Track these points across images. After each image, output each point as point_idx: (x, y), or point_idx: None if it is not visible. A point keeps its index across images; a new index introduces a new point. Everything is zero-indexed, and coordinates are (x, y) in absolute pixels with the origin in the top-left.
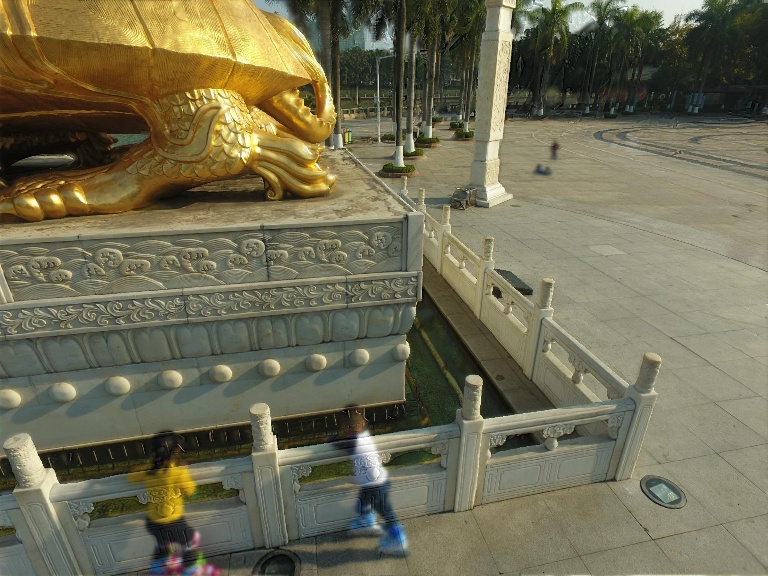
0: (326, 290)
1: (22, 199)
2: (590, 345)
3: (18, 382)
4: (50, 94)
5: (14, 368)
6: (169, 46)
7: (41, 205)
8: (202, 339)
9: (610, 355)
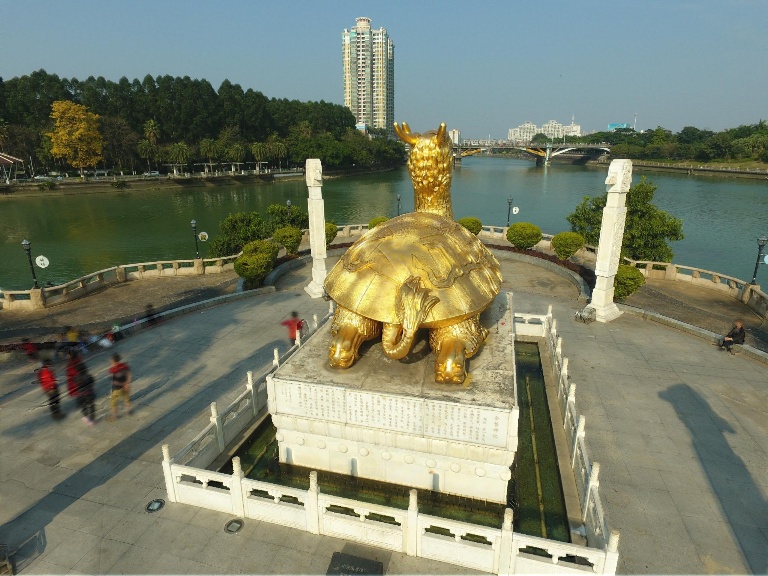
0: None
1: None
2: (231, 572)
3: None
4: None
5: None
6: None
7: None
8: None
9: (213, 574)
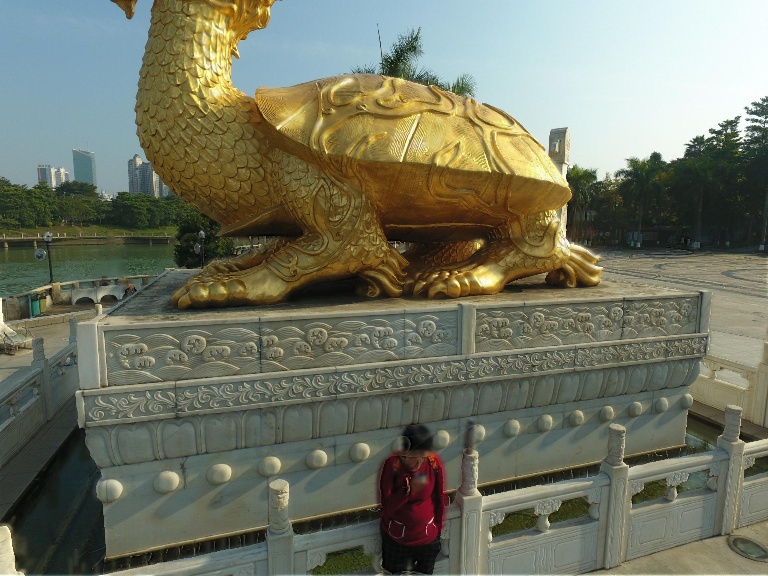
0: (656, 346)
1: (453, 281)
2: None
3: (451, 424)
4: (482, 211)
5: (456, 410)
6: (559, 183)
7: (461, 286)
8: (576, 386)
9: None
